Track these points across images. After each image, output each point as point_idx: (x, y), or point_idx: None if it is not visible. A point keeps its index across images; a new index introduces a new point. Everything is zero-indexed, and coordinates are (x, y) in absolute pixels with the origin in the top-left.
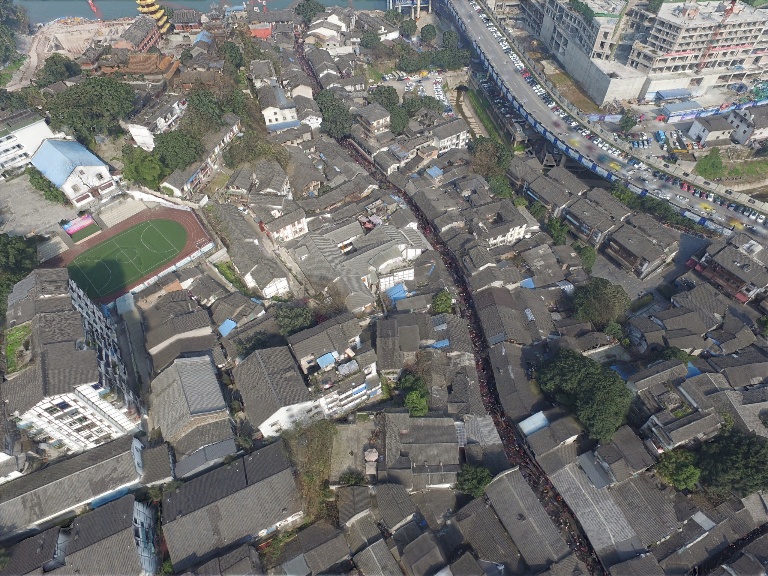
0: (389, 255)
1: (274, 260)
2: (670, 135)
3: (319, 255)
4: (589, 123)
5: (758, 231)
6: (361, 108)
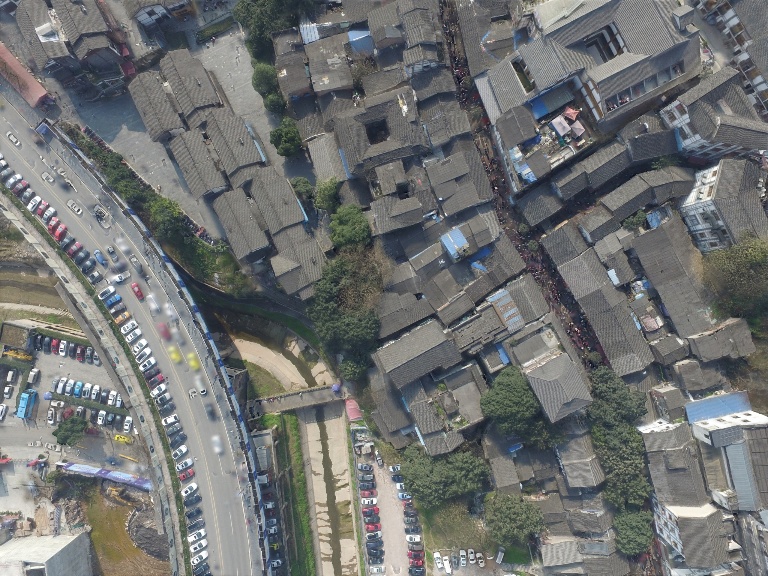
0: (557, 7)
1: (721, 1)
2: (7, 414)
3: (658, 3)
4: (143, 418)
5: (7, 128)
6: (585, 398)
